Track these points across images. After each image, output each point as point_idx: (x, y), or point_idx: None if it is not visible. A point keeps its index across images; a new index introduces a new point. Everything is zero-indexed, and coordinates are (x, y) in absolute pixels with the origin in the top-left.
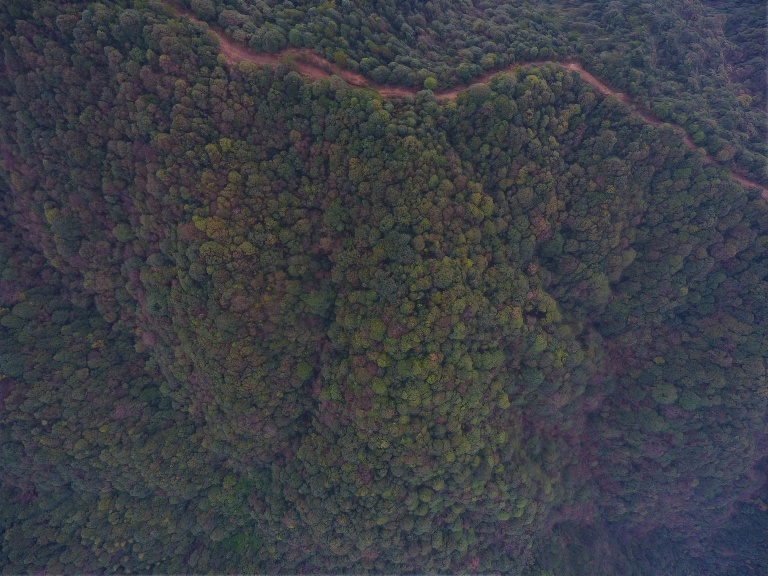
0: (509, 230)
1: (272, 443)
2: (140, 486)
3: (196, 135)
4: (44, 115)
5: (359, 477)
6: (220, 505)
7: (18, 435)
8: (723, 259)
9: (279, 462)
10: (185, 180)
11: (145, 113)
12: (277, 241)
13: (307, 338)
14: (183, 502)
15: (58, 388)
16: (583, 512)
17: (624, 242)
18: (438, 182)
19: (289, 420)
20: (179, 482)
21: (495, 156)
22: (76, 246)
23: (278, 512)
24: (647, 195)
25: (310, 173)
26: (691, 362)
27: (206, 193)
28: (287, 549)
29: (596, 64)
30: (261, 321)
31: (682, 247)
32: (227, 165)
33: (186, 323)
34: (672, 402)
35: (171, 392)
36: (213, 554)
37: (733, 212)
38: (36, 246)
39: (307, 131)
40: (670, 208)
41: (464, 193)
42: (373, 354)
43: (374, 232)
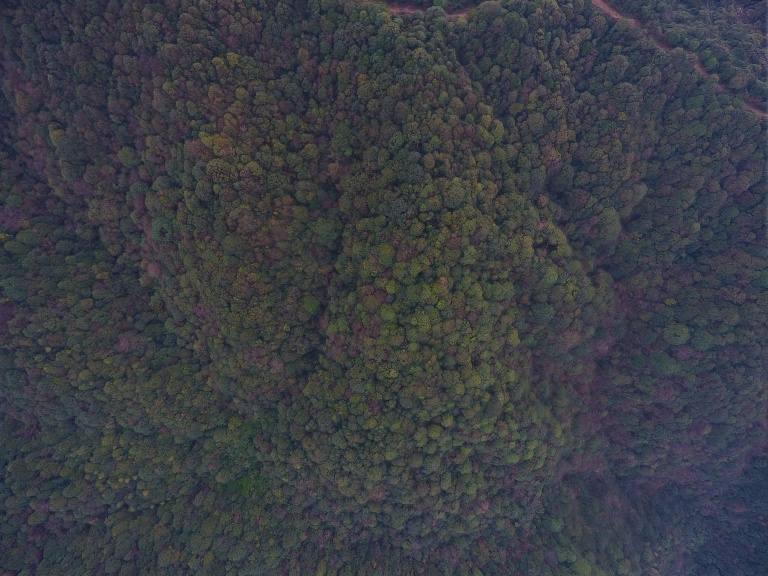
0: (519, 158)
1: (278, 380)
2: (145, 422)
3: (203, 47)
4: (49, 27)
5: (367, 408)
6: (225, 446)
7: (21, 362)
8: (736, 193)
9: (285, 401)
10: (192, 94)
11: (152, 23)
12: (284, 165)
13: (314, 269)
14: (188, 442)
15: (62, 316)
16: (593, 464)
17: (635, 175)
18: (448, 99)
19: (296, 356)
20: (184, 420)
21: (505, 78)
22: (81, 171)
23: (284, 452)
24: (659, 126)
25: (318, 94)
26: (703, 301)
27: (213, 109)
28: (293, 492)
29: None
30: (268, 247)
31: (694, 179)
32: (234, 81)
33: (192, 247)
34: (684, 342)
35: (176, 327)
36: (218, 496)
37: (746, 142)
38: (40, 174)
39: (315, 49)
40: (682, 139)
41: (474, 114)
42: (382, 280)
43: (383, 152)
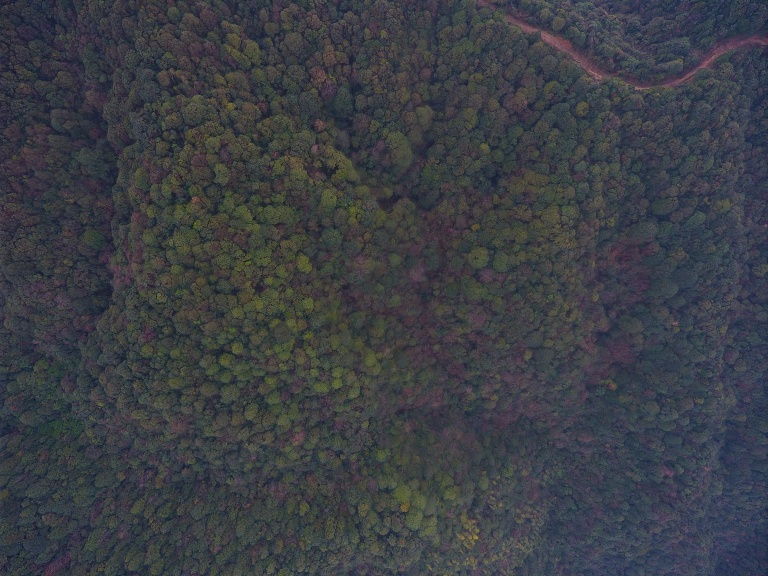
0: (283, 80)
1: (72, 318)
2: None
3: None
4: None
5: (141, 335)
6: (31, 389)
7: None
8: (516, 111)
9: (84, 339)
10: None
11: None
12: (34, 92)
13: (88, 201)
14: None
15: None
16: (430, 398)
17: (415, 97)
18: (180, 15)
19: (85, 292)
20: None
21: None
22: None
23: (85, 390)
24: (432, 46)
25: (61, 19)
26: (500, 222)
27: None
28: (105, 432)
29: None
30: (26, 177)
31: (471, 98)
32: None
33: None
34: (485, 265)
35: None
36: (26, 439)
37: (516, 58)
38: None
39: None
40: (454, 57)
41: (216, 31)
42: (142, 205)
43: (124, 73)
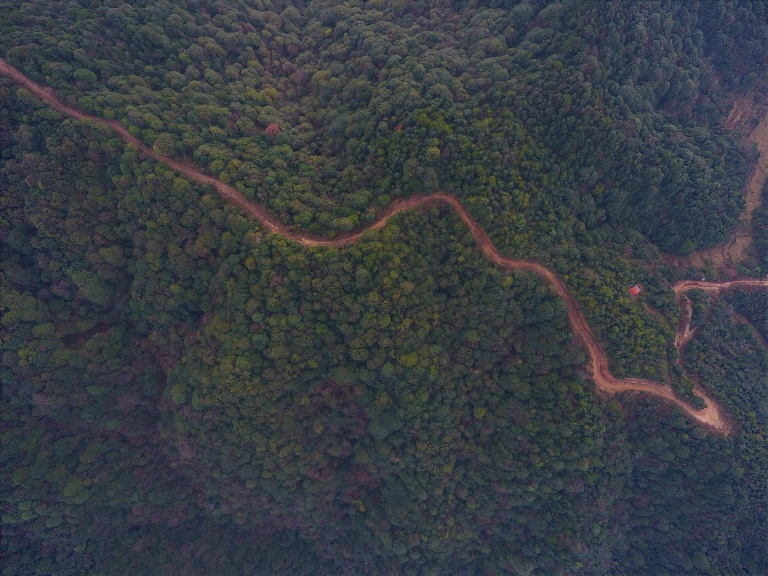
0: None
1: None
2: None
3: None
4: None
5: None
6: None
7: None
8: (200, 256)
9: None
10: None
11: None
12: None
13: None
14: None
15: None
16: (168, 514)
17: (96, 239)
18: None
19: None
20: None
21: None
22: None
23: None
24: (108, 191)
25: None
26: (196, 361)
27: None
28: None
29: (7, 58)
30: None
31: (148, 244)
32: None
33: None
34: (182, 402)
35: None
36: None
37: (188, 208)
38: None
39: None
40: (127, 204)
41: None
42: None
43: None
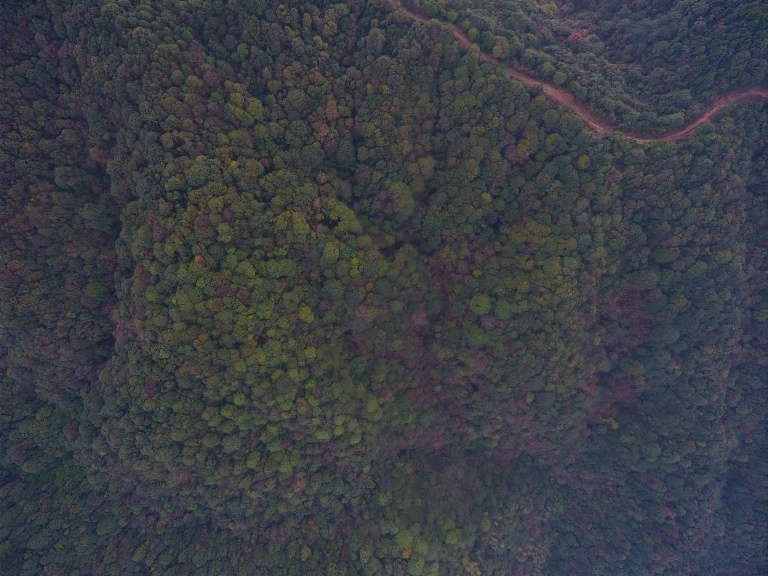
0: (285, 135)
1: (74, 368)
2: None
3: None
4: None
5: (144, 390)
6: (33, 437)
7: None
8: (518, 161)
9: (86, 388)
10: None
11: None
12: (38, 151)
13: (91, 255)
14: None
15: None
16: (431, 438)
17: (417, 148)
18: (183, 78)
19: (88, 343)
20: None
21: (254, 56)
22: None
23: (87, 439)
24: (434, 99)
25: (65, 79)
26: (502, 270)
27: None
28: (107, 479)
29: None
30: (30, 234)
31: (473, 150)
32: None
33: None
34: (487, 312)
35: None
36: (28, 487)
37: (518, 111)
38: None
39: (52, 34)
40: (456, 110)
41: (219, 92)
42: (145, 262)
43: (128, 134)
